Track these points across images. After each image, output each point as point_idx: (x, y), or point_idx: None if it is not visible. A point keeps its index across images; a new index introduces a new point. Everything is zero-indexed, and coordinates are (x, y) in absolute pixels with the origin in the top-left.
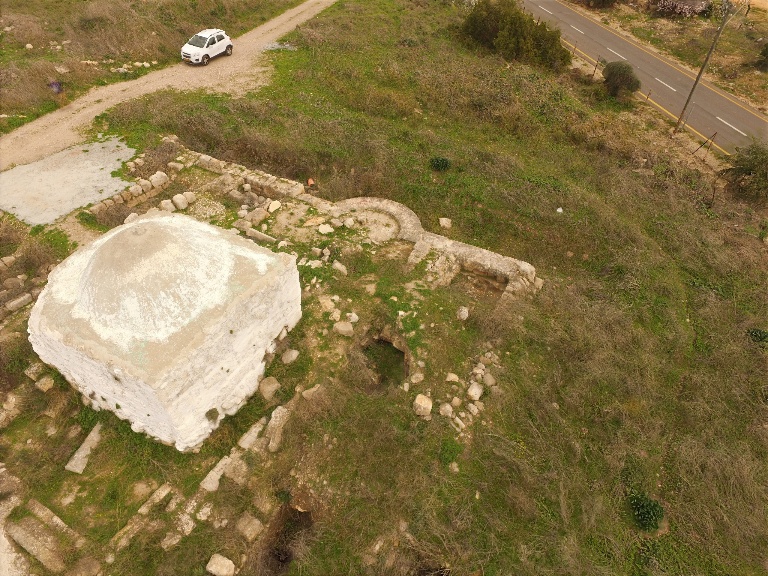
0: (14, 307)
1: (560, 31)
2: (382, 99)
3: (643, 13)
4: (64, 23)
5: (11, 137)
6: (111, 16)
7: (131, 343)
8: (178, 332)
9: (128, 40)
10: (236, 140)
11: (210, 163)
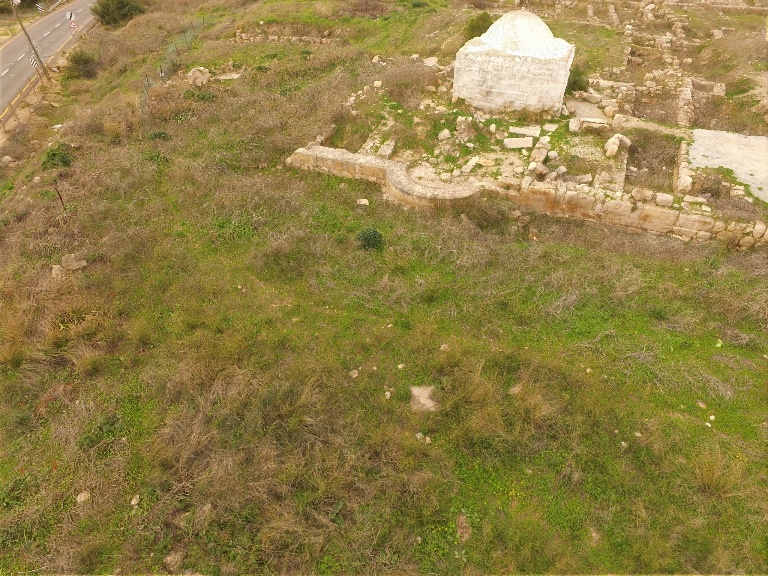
0: None
1: None
2: None
3: None
4: None
5: None
6: None
7: None
8: None
9: None
10: None
11: None
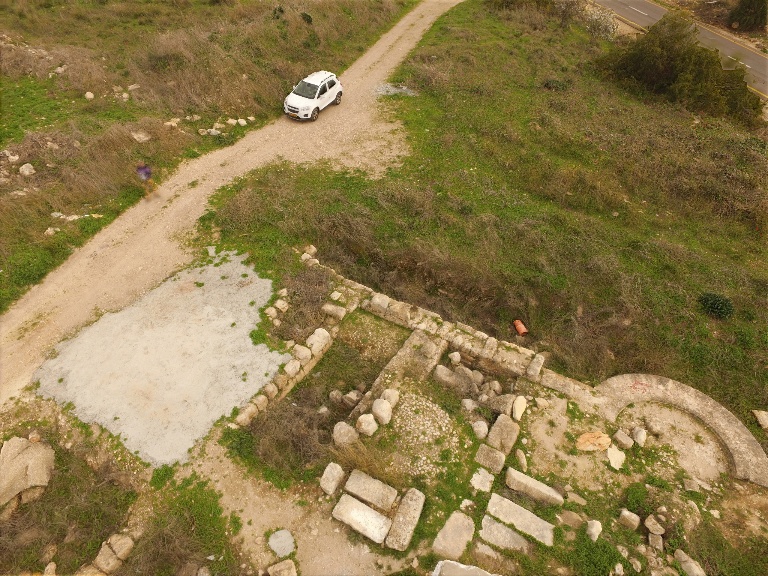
0: None
1: (745, 70)
2: (573, 181)
3: None
4: (128, 60)
5: (86, 253)
6: (187, 51)
7: None
8: None
9: (214, 86)
10: (404, 258)
11: (389, 311)
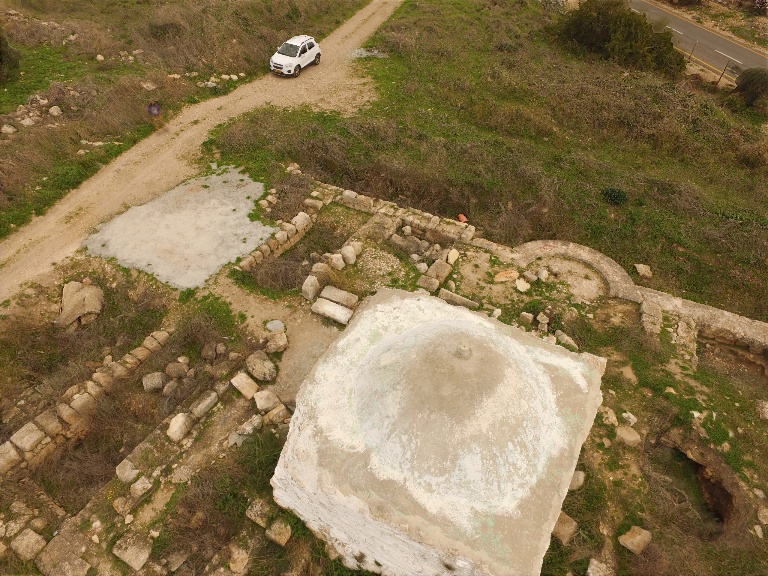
0: (201, 412)
1: (671, 33)
2: (513, 116)
3: (737, 11)
4: (131, 30)
5: (112, 169)
6: (183, 22)
7: (473, 519)
8: (528, 497)
9: (208, 49)
10: (370, 169)
11: (357, 200)
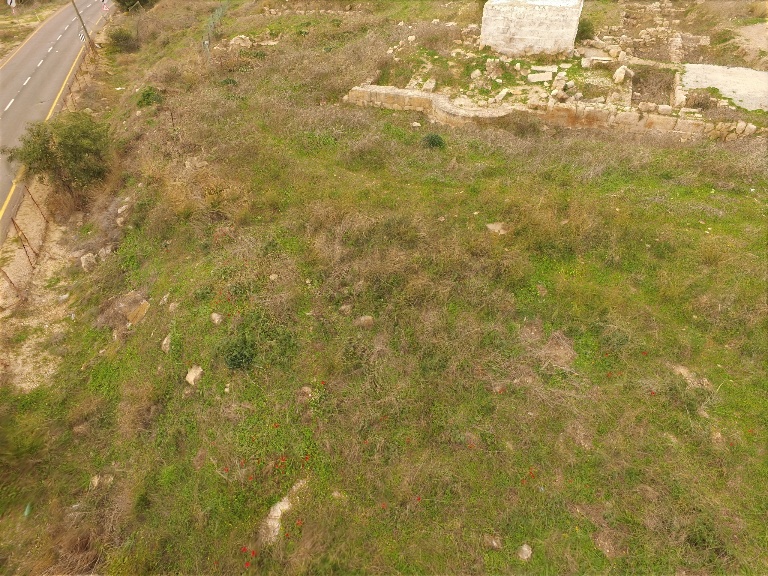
0: None
1: None
2: None
3: None
4: None
5: None
6: None
7: None
8: None
9: None
10: None
11: None
